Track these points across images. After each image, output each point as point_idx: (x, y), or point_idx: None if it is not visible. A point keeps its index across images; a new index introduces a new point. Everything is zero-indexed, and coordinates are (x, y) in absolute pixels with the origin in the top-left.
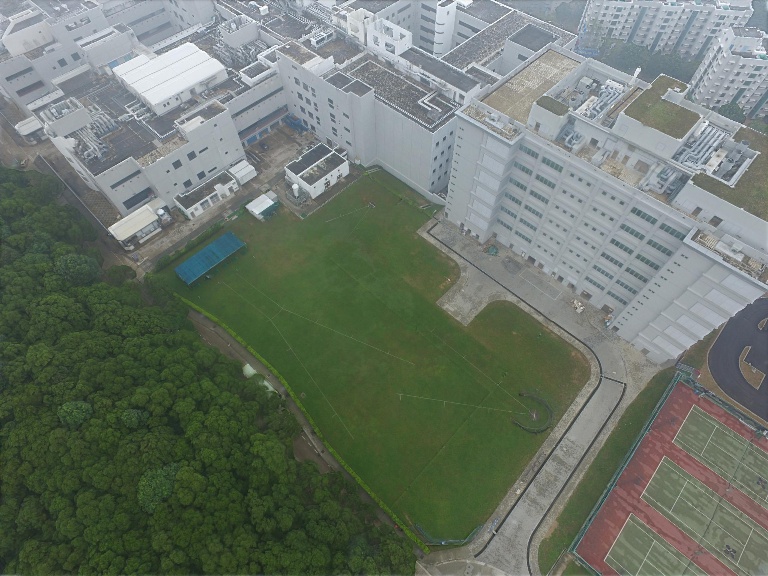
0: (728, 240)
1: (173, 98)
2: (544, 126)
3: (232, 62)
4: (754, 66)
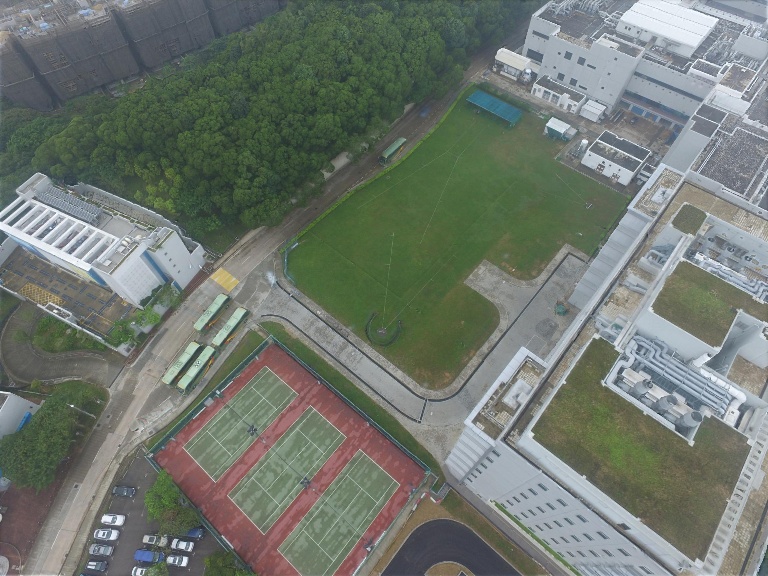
0: None
1: (637, 29)
2: None
3: (715, 56)
4: None
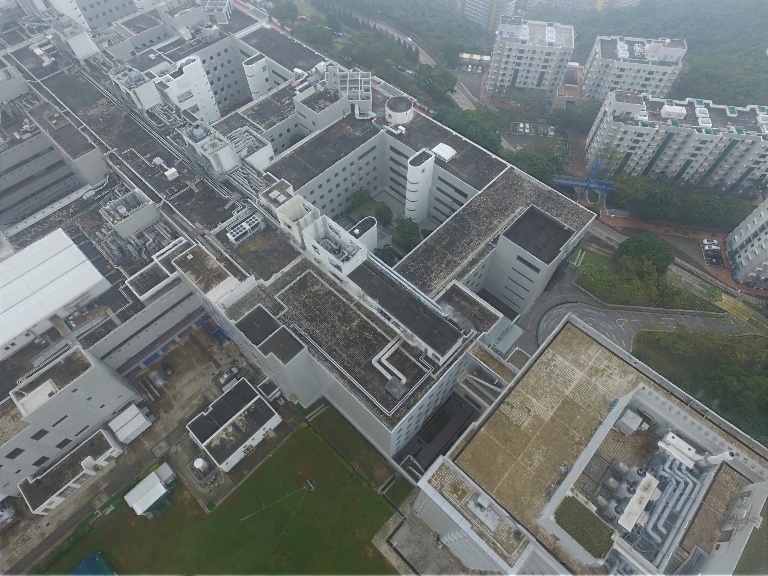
0: None
1: (20, 336)
2: (567, 545)
3: (122, 256)
4: None
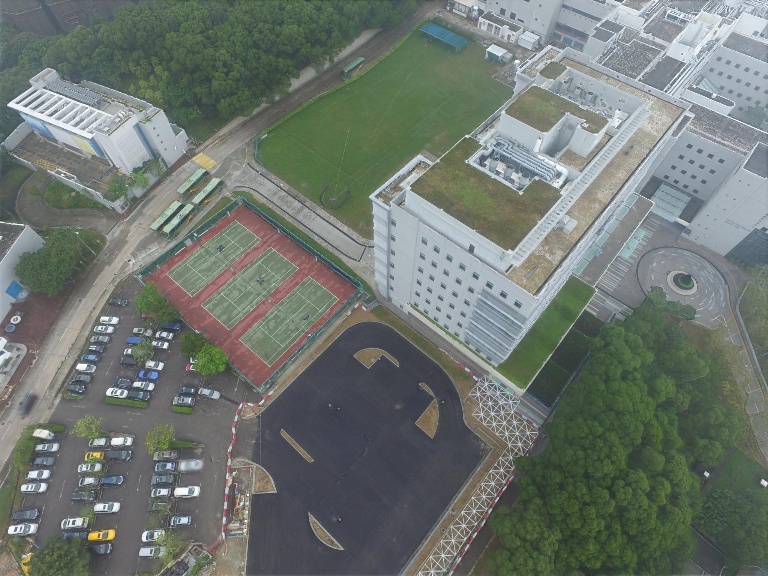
0: None
1: None
2: None
3: None
4: None
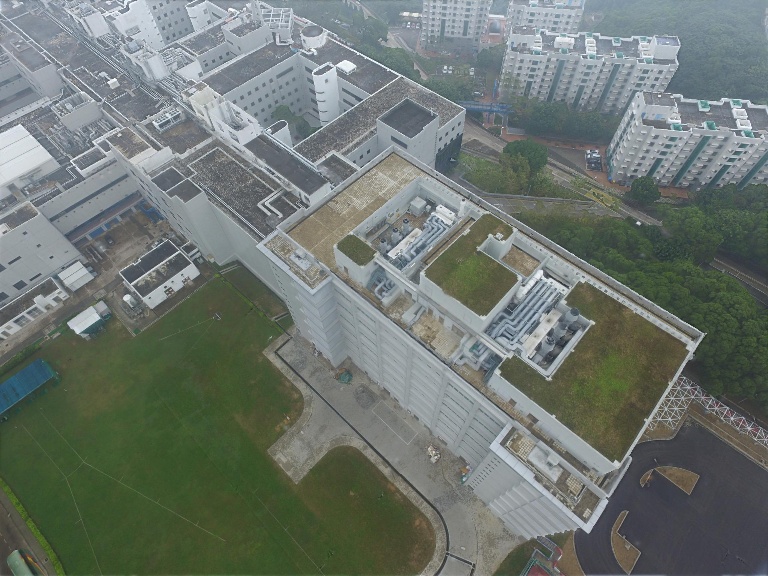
0: (544, 448)
1: None
2: (351, 271)
3: (70, 146)
4: (668, 137)
